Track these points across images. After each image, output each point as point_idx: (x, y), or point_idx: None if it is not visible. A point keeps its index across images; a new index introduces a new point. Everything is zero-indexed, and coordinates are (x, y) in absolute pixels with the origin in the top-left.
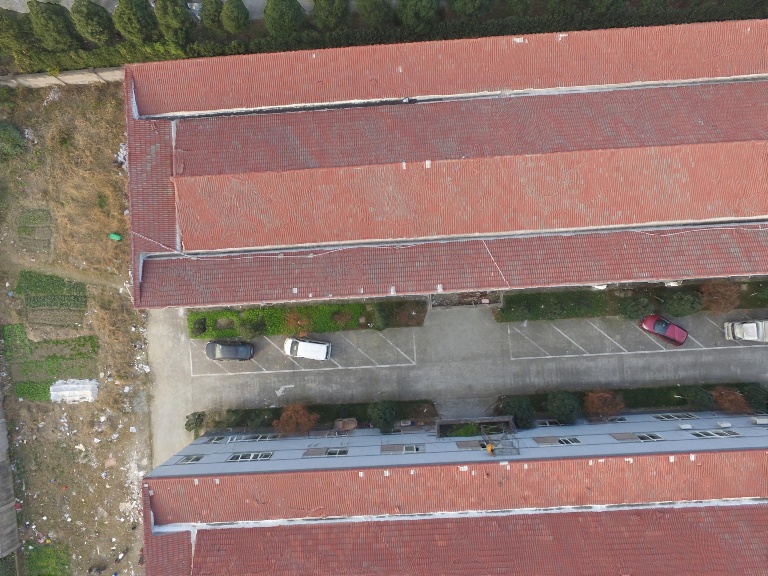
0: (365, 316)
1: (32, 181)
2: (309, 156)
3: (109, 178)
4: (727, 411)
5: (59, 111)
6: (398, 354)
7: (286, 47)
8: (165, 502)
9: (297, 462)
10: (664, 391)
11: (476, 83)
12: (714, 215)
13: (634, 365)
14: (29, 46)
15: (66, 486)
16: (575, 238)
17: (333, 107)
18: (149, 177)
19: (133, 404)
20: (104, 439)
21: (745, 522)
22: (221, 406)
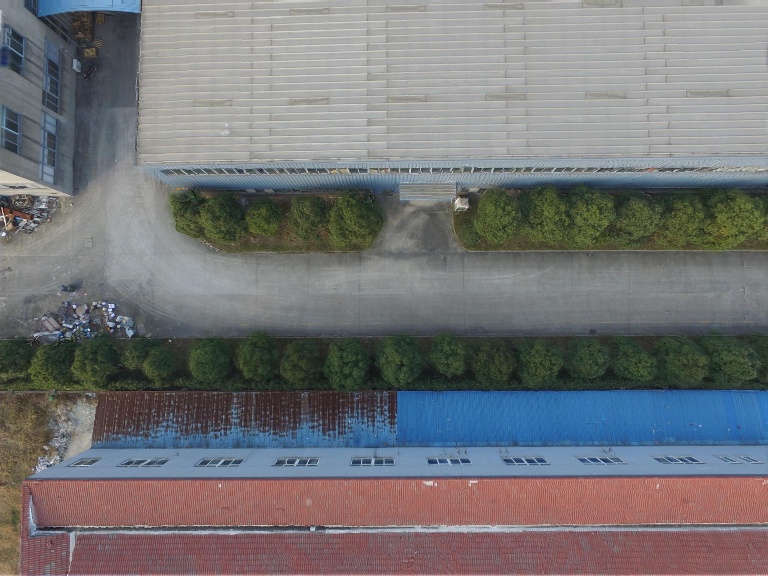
0: None
1: None
2: None
3: None
4: None
5: None
6: None
7: (211, 389)
8: None
9: None
10: None
11: None
12: None
13: None
14: None
15: None
16: None
17: (239, 528)
18: None
19: None
20: None
21: None
22: None
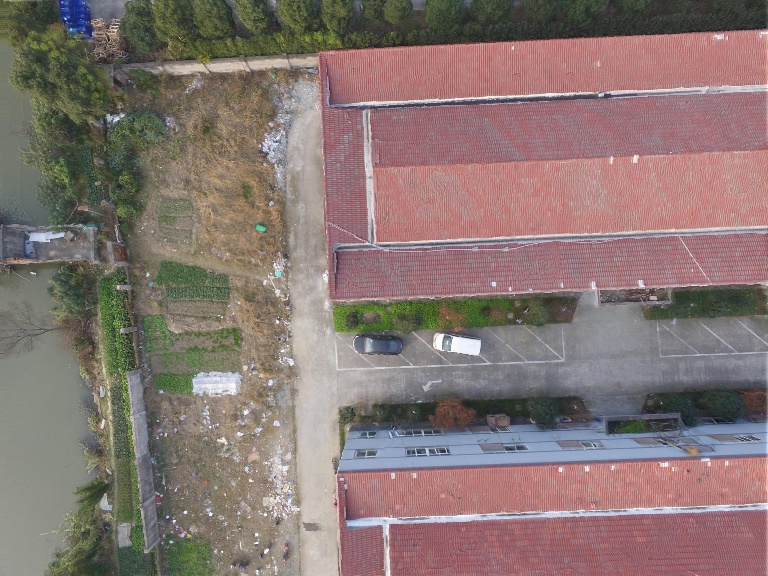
0: (513, 312)
1: (173, 170)
2: (504, 149)
3: (253, 168)
4: None
5: (201, 99)
6: (547, 350)
7: (444, 39)
8: (359, 496)
9: (485, 457)
10: None
11: (675, 79)
12: None
13: None
14: (186, 32)
15: (208, 480)
16: None
17: (526, 100)
18: (342, 167)
19: (277, 398)
20: (247, 433)
21: None
22: (367, 401)
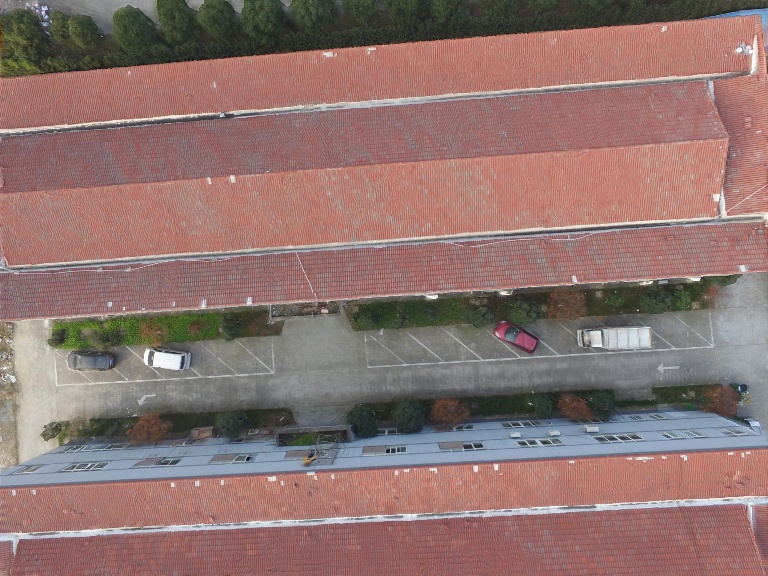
0: None
1: None
2: None
3: None
4: (566, 419)
5: None
6: (257, 363)
7: (139, 61)
8: None
9: (120, 472)
10: (519, 398)
11: (288, 97)
12: (523, 226)
13: (489, 372)
14: None
15: None
16: (386, 250)
17: (153, 122)
18: None
19: None
20: None
21: (550, 531)
22: (85, 415)
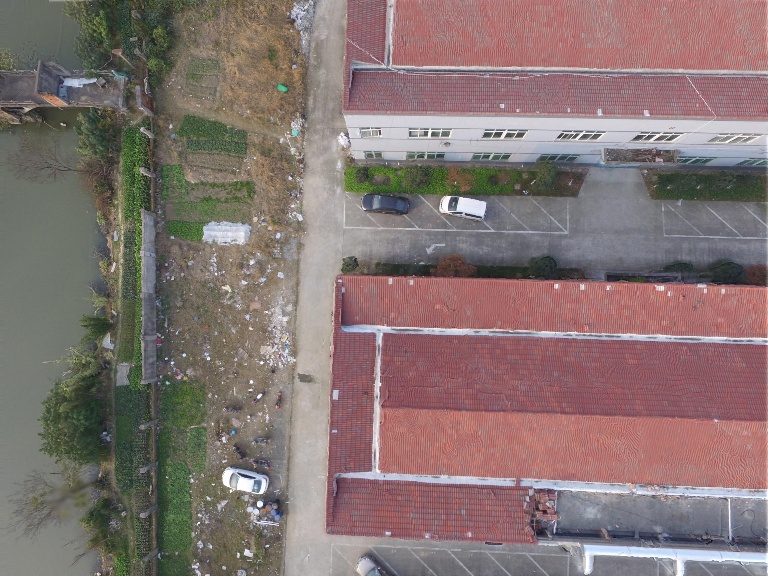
0: (521, 183)
1: (204, 32)
2: None
3: (280, 34)
4: None
5: None
6: (551, 222)
7: None
8: (355, 301)
9: None
10: None
11: None
12: None
13: None
14: None
15: (209, 325)
16: None
17: None
18: None
19: (283, 250)
20: (251, 282)
21: None
22: (371, 259)
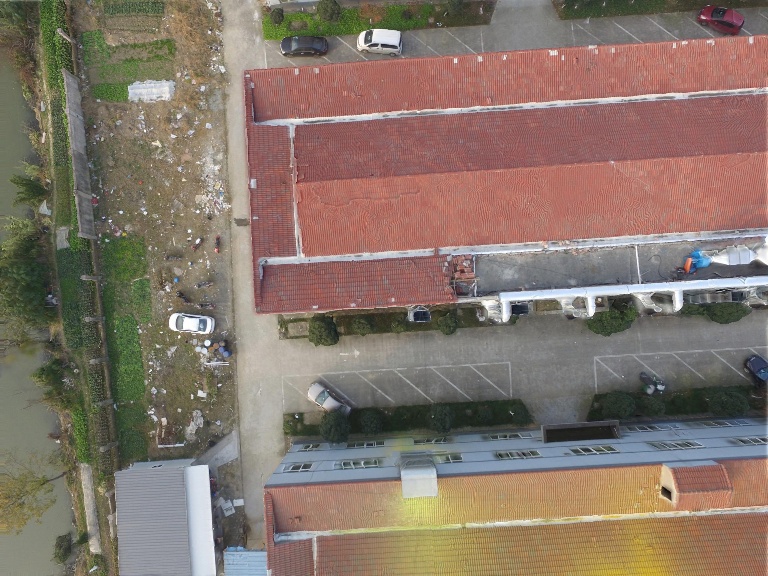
0: (434, 16)
1: None
2: None
3: None
4: None
5: None
6: (466, 51)
7: None
8: (265, 96)
9: None
10: None
11: None
12: None
13: None
14: None
15: (142, 181)
16: None
17: None
18: None
19: (209, 102)
20: (180, 135)
21: None
22: None
